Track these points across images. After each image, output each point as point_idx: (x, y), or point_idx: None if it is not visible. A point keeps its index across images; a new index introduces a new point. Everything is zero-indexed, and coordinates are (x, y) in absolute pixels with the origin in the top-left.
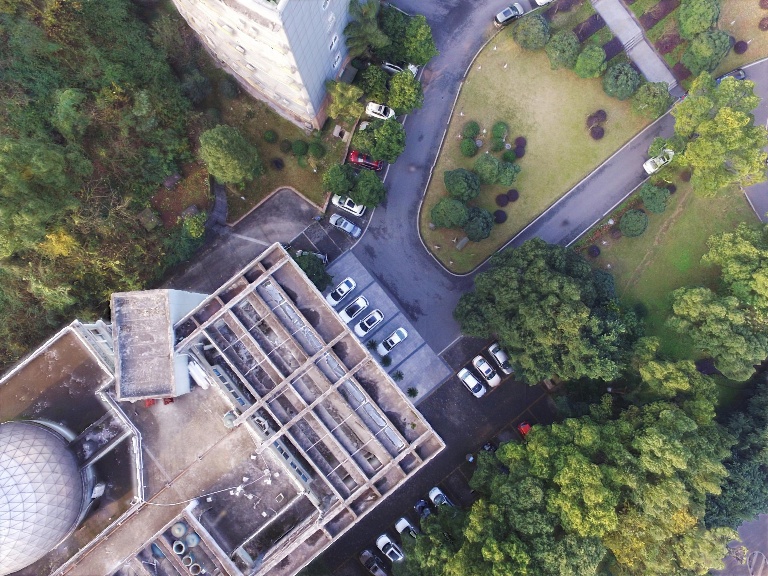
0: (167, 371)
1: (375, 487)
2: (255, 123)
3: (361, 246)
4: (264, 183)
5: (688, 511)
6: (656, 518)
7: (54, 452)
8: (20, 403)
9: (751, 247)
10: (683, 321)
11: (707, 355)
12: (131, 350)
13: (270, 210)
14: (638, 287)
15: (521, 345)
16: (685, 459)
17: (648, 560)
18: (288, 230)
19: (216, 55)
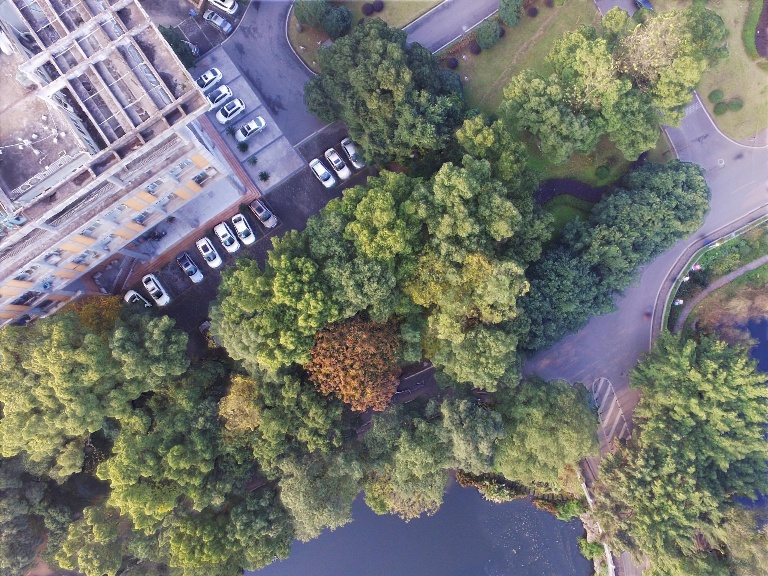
0: None
1: (141, 136)
2: None
3: (231, 43)
4: None
5: (488, 262)
6: (452, 260)
7: None
8: None
9: (579, 34)
10: (509, 100)
11: (561, 176)
12: None
13: (150, 4)
14: (494, 101)
15: (353, 113)
16: (466, 181)
17: (441, 299)
18: (165, 23)
19: None
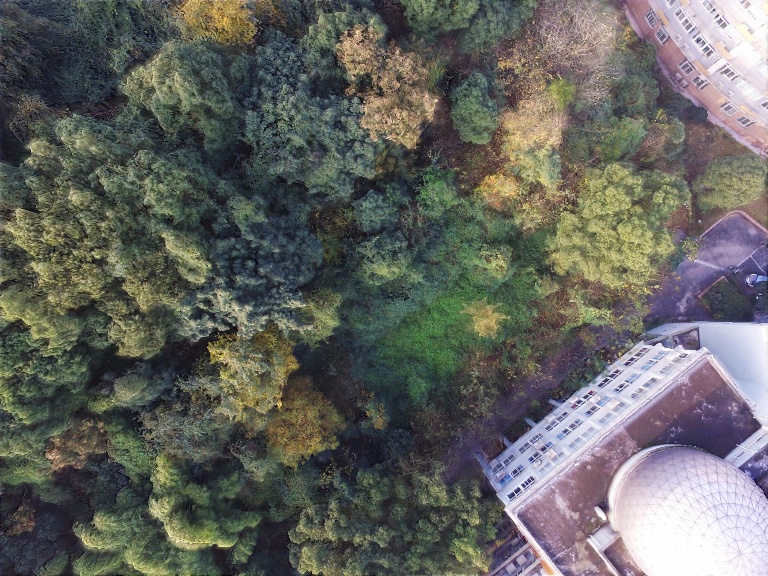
0: None
1: None
2: (713, 148)
3: None
4: None
5: None
6: None
7: None
8: (655, 427)
9: None
10: None
11: None
12: None
13: (719, 233)
14: None
15: None
16: None
17: None
18: (736, 253)
19: (681, 80)
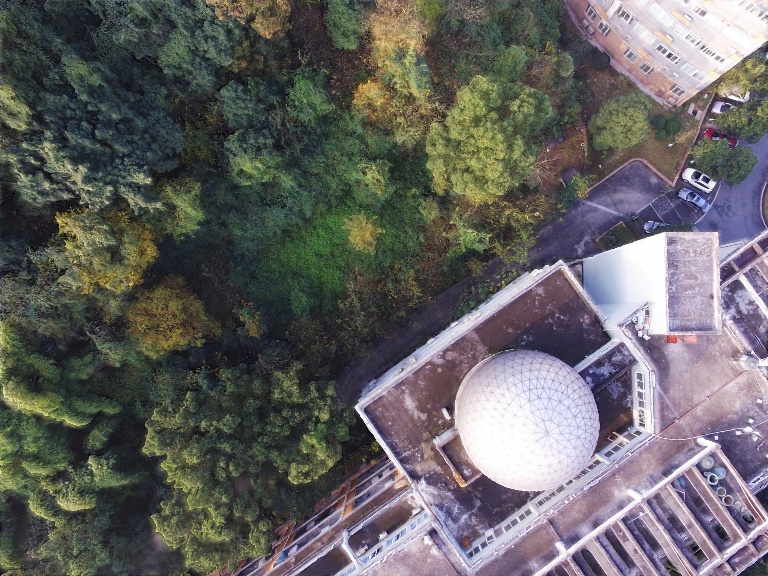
0: (709, 310)
1: None
2: (617, 95)
3: (705, 222)
4: (620, 153)
5: None
6: None
7: (583, 379)
8: (507, 334)
9: None
10: None
11: None
12: (677, 287)
13: (620, 180)
14: None
15: None
16: None
17: None
18: (636, 201)
19: (587, 27)
